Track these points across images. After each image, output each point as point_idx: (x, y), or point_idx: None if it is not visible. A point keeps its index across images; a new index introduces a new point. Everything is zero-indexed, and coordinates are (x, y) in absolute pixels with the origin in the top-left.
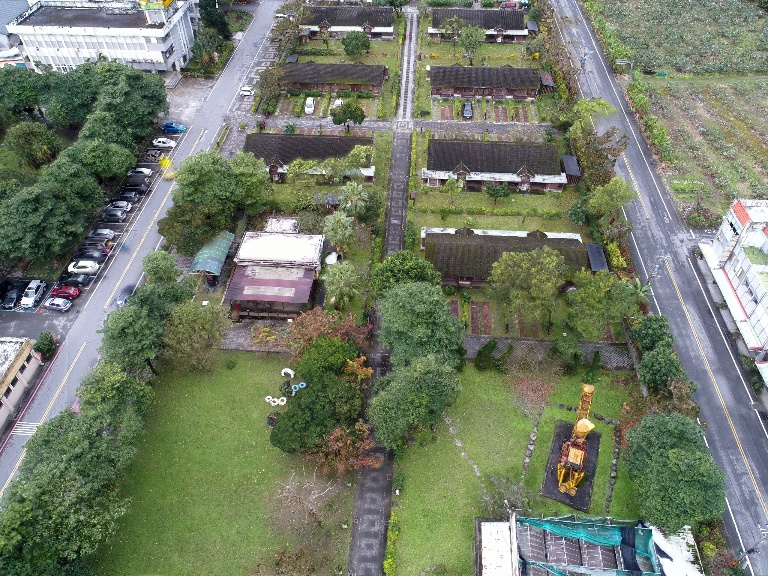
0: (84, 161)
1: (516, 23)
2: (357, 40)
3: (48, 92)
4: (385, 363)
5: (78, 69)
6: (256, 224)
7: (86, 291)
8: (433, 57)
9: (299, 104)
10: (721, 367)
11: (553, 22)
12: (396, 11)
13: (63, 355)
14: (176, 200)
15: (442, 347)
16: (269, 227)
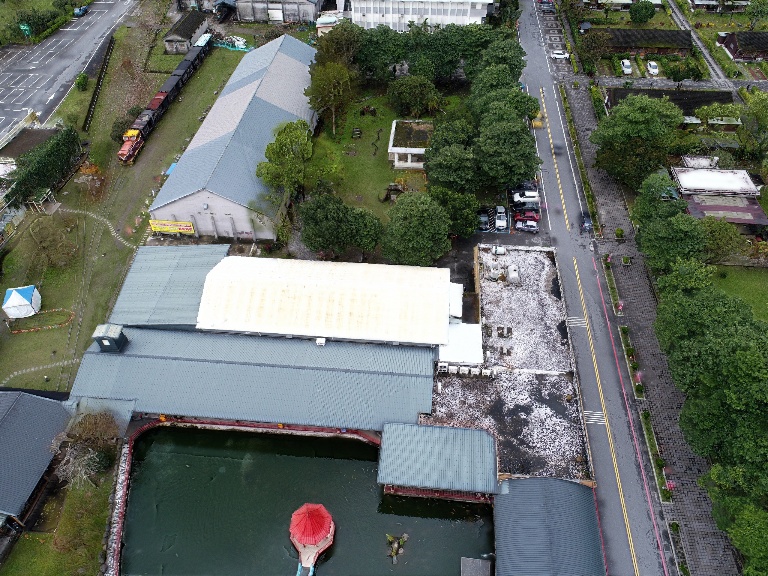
0: None
1: None
2: (647, 9)
3: (415, 50)
4: None
5: (445, 29)
6: (668, 162)
7: (541, 217)
8: (709, 26)
9: (618, 65)
10: None
11: None
12: None
13: (562, 266)
14: (612, 138)
15: None
16: (689, 164)
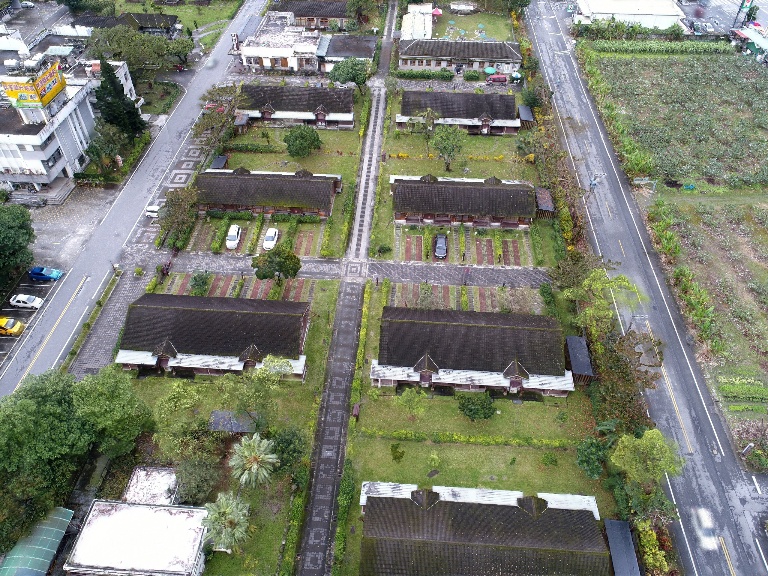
0: None
1: (506, 111)
2: (303, 139)
3: None
4: None
5: None
6: (117, 476)
7: None
8: (401, 157)
9: (219, 236)
10: None
11: (551, 107)
12: (359, 88)
13: None
14: None
15: None
16: (132, 489)
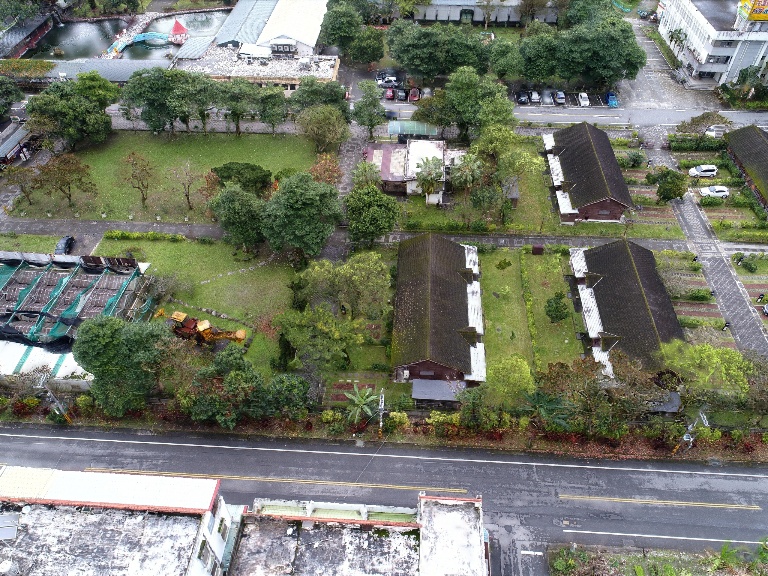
0: (492, 48)
1: None
2: None
3: None
4: None
5: None
6: None
7: (394, 101)
8: None
9: (696, 161)
10: (269, 494)
11: None
12: None
13: None
14: None
15: None
16: (453, 152)
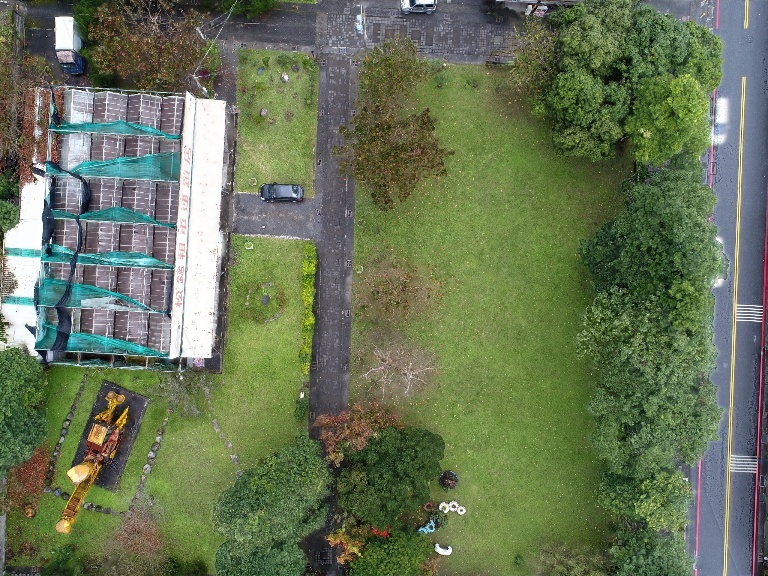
0: None
1: None
2: None
3: None
4: (322, 571)
5: None
6: None
7: None
8: None
9: None
10: None
11: None
12: None
13: (745, 574)
14: None
15: (233, 571)
16: None
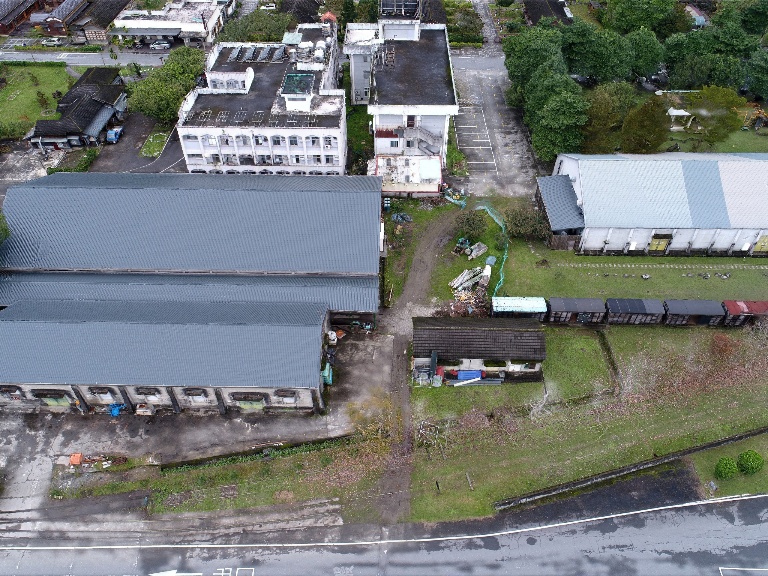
0: None
1: None
2: None
3: None
4: None
5: (542, 51)
6: None
7: None
8: None
9: None
10: None
11: None
12: None
13: None
14: None
15: None
16: None
